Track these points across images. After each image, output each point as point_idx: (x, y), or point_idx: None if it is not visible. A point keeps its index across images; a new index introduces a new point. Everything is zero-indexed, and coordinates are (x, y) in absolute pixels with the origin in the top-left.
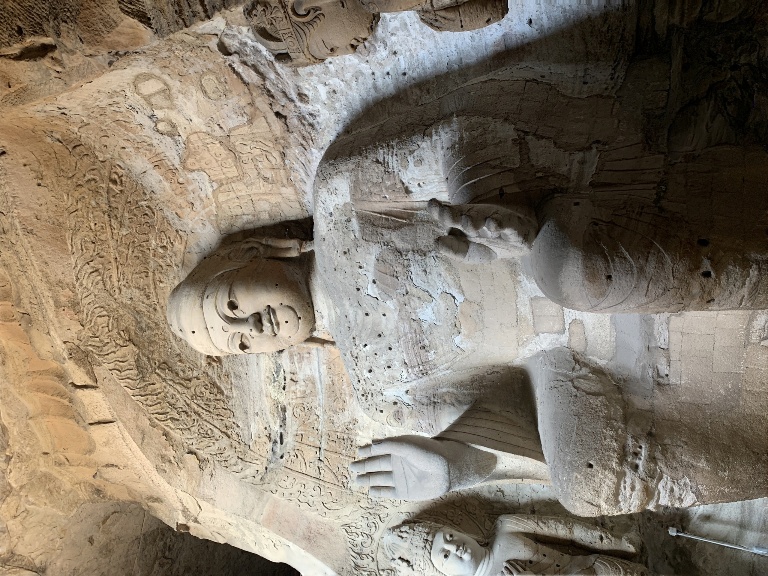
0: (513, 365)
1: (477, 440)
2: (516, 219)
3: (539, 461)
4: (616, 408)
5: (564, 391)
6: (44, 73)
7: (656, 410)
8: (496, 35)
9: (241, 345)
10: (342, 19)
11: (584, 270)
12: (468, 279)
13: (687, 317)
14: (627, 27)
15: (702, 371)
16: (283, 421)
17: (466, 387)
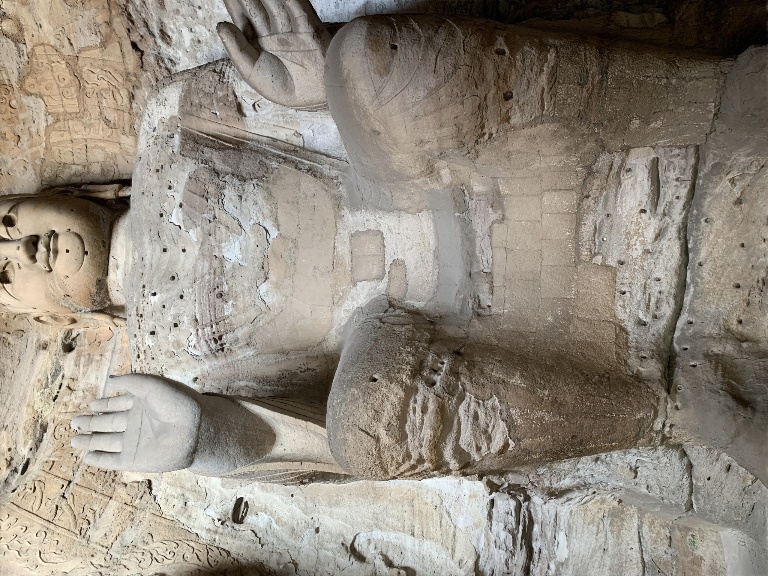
0: (329, 350)
1: (253, 401)
2: (308, 1)
3: (325, 428)
4: (423, 334)
5: (368, 326)
6: None
7: (471, 337)
8: (358, 3)
9: (3, 277)
10: None
11: (368, 37)
12: (286, 211)
13: (510, 223)
14: (474, 3)
15: (528, 297)
16: (37, 442)
17: (270, 383)
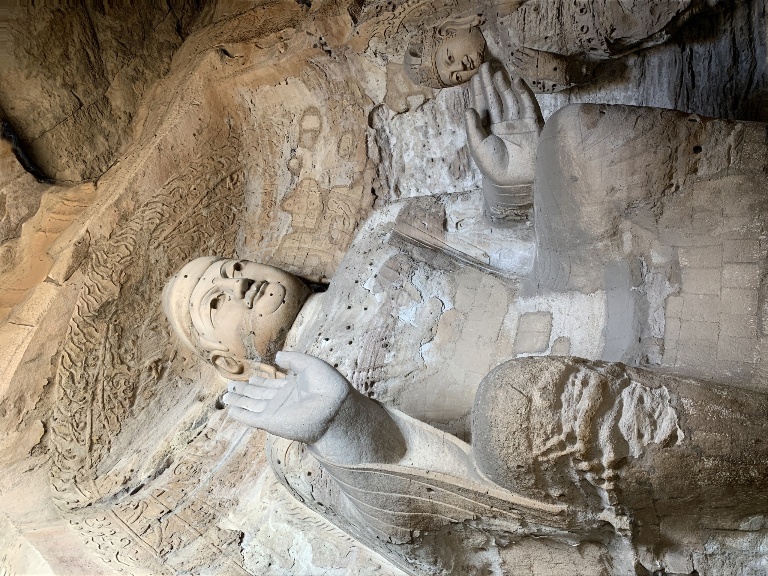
0: None
1: None
2: None
3: None
4: None
5: None
6: (271, 55)
7: None
8: None
9: (213, 304)
10: (466, 38)
11: (582, 107)
12: (465, 293)
13: (687, 296)
14: None
15: (703, 358)
16: (157, 473)
17: None
